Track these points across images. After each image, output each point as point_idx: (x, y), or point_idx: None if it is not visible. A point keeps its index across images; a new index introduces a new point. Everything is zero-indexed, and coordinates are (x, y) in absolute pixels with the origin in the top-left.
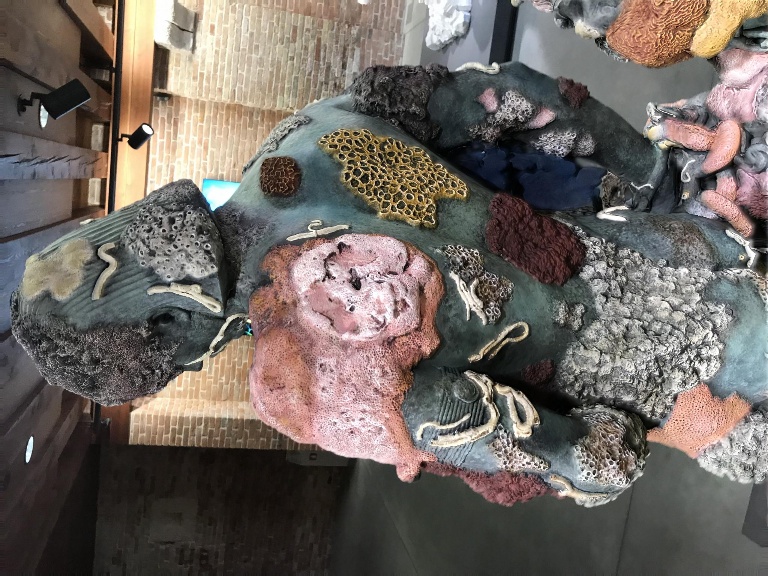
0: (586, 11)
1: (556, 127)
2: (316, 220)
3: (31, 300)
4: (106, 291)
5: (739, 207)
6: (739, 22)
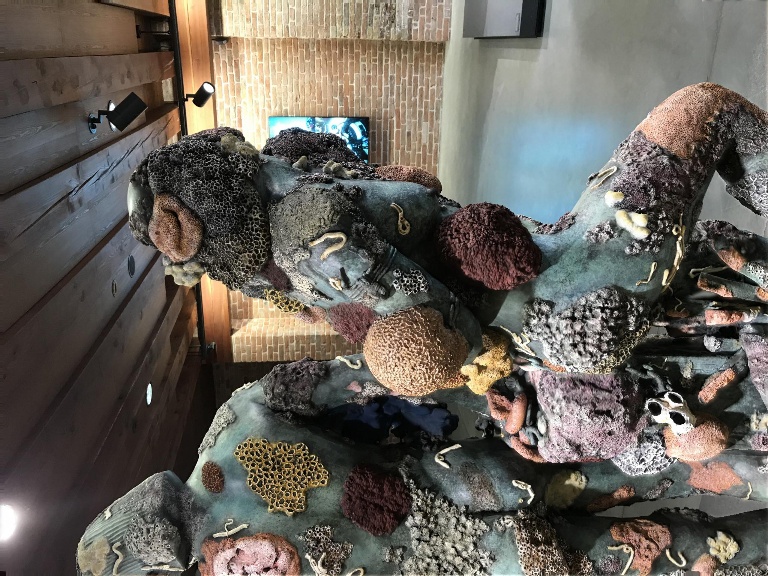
0: None
1: None
2: (230, 519)
3: (83, 573)
4: (120, 570)
5: None
6: None
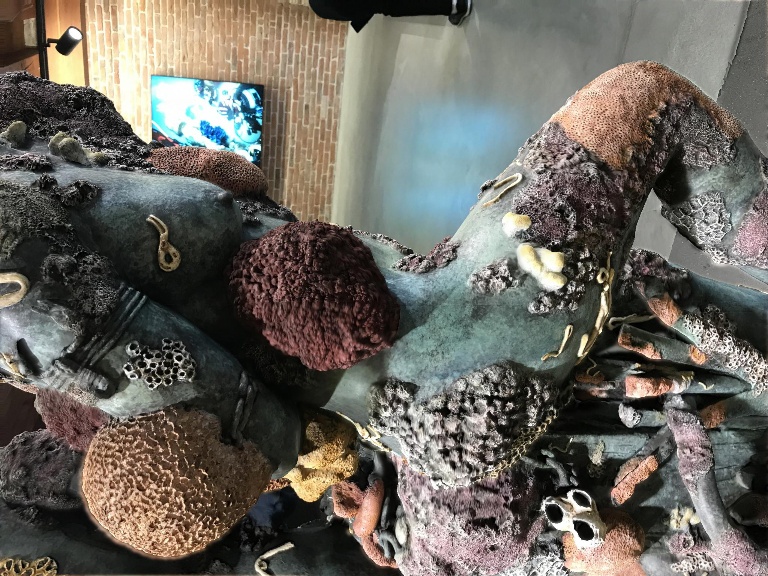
0: None
1: None
2: None
3: None
4: None
5: None
6: (319, 495)
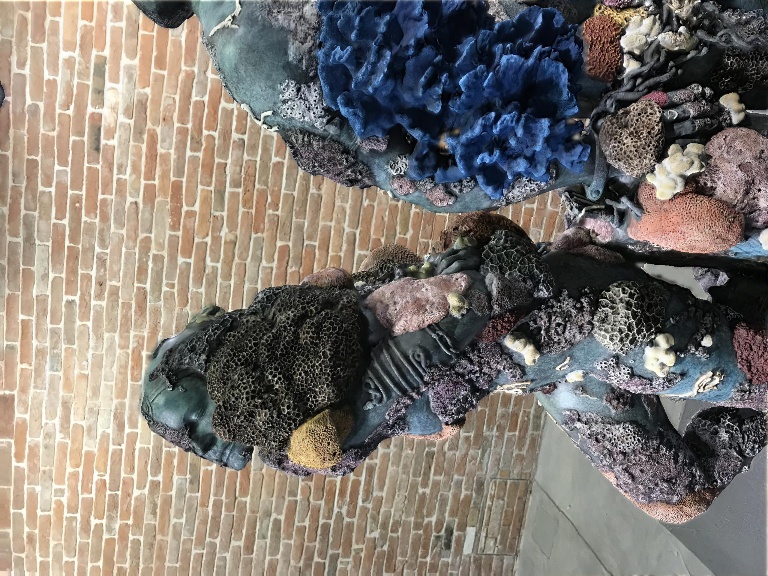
0: None
1: None
2: None
3: None
4: None
5: None
6: None
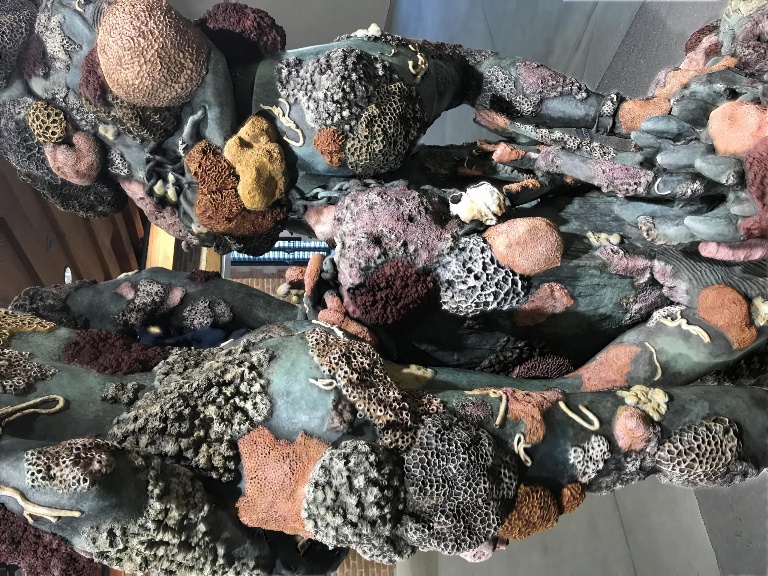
0: (191, 214)
1: (191, 300)
2: None
3: None
4: None
5: (356, 319)
6: (255, 170)
